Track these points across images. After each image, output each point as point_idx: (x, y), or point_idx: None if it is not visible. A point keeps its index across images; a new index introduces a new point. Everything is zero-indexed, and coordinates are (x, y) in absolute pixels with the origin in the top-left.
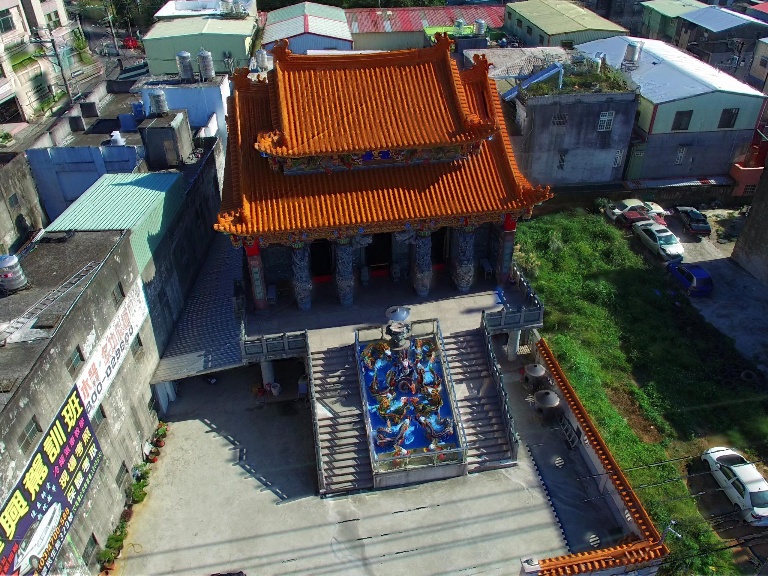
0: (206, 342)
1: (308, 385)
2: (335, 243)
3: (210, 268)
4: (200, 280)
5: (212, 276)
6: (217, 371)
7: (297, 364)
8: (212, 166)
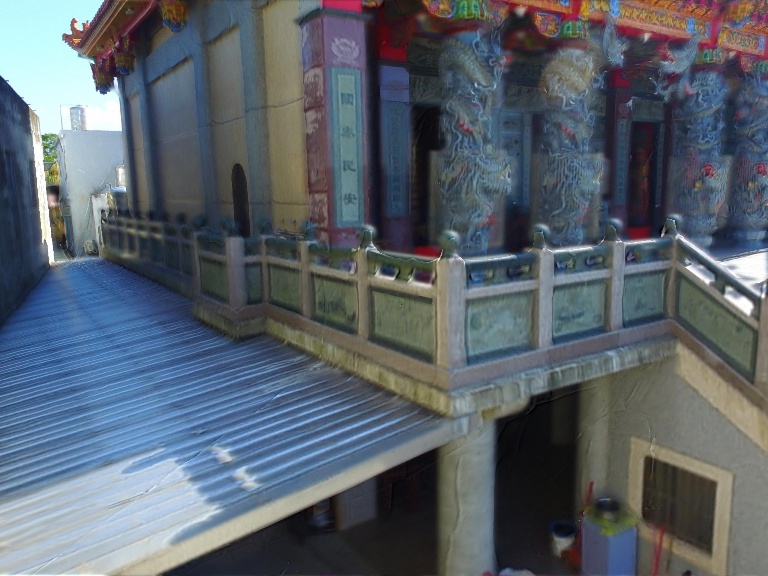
0: (142, 416)
1: (643, 535)
2: (554, 42)
3: (45, 309)
4: (16, 328)
5: (61, 316)
6: (316, 503)
7: (565, 454)
8: (26, 133)
